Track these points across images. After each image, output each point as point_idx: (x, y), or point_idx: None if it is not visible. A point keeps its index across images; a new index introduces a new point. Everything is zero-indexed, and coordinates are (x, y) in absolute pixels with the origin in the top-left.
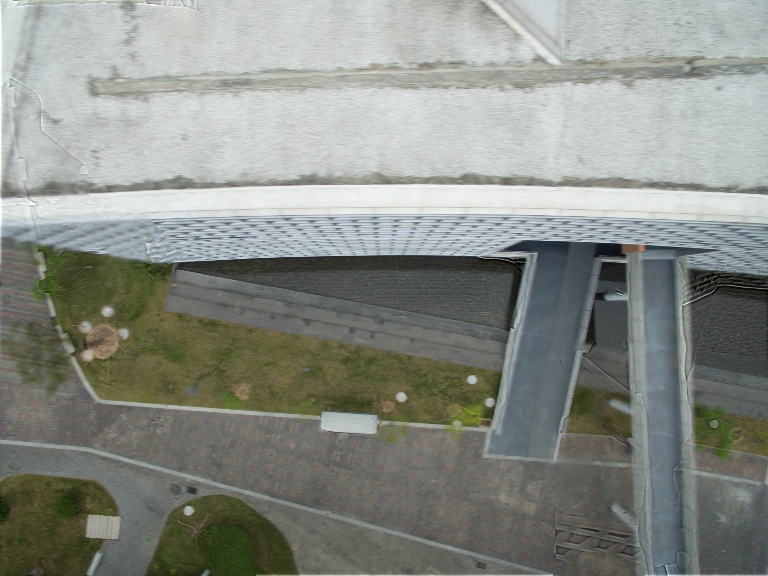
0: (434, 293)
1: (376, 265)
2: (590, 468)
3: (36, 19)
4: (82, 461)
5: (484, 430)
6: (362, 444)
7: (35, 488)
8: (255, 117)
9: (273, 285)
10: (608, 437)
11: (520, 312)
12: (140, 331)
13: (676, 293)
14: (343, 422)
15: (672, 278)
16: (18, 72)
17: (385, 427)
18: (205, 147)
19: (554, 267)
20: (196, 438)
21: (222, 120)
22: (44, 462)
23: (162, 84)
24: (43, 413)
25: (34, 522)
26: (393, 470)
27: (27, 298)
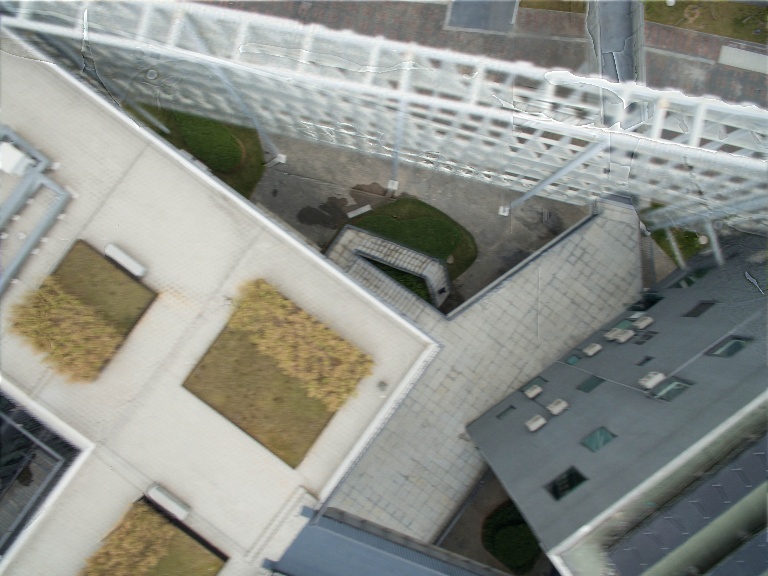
0: None
1: None
2: (548, 42)
3: None
4: (46, 25)
5: (445, 3)
6: (324, 13)
7: None
8: None
9: None
10: (567, 13)
11: None
12: None
13: None
14: None
15: None
16: None
17: None
18: None
19: None
20: (160, 4)
21: None
22: (8, 25)
23: None
24: None
25: None
26: (355, 39)
27: None
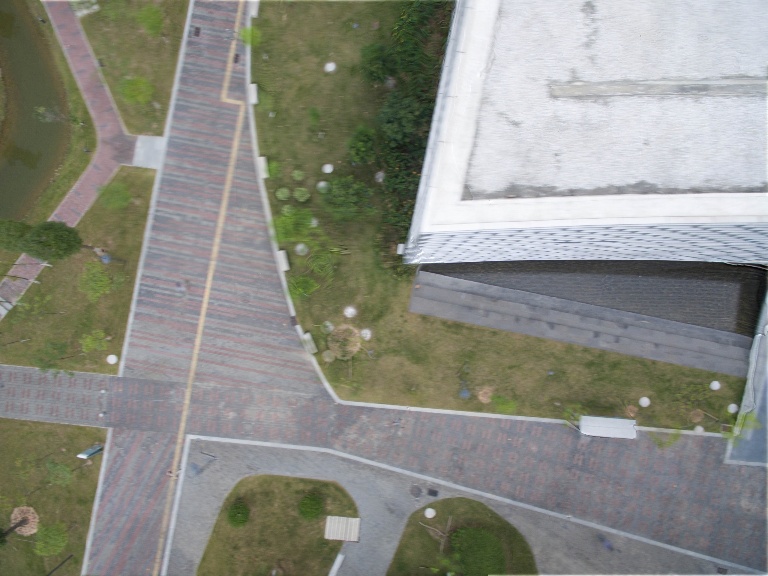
0: (676, 298)
1: (620, 269)
2: None
3: (500, 20)
4: (322, 462)
5: (726, 436)
6: (604, 448)
7: (275, 489)
8: (717, 123)
9: (516, 288)
10: None
11: None
12: (383, 332)
13: None
14: (603, 426)
15: None
16: (483, 73)
17: None
18: (667, 152)
19: None
20: (438, 440)
21: (684, 125)
22: (283, 462)
23: (619, 88)
24: (283, 413)
25: (275, 523)
26: (635, 475)
27: (266, 297)
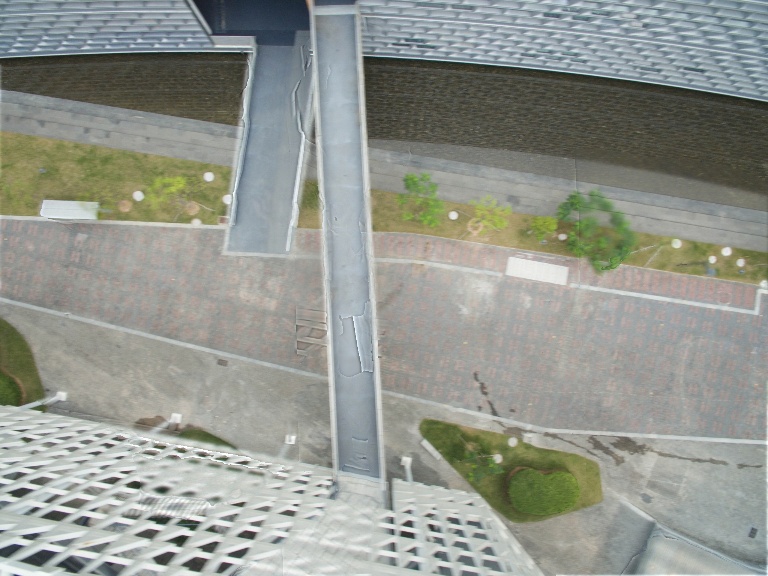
0: (172, 93)
1: (111, 65)
2: None
3: None
4: None
5: (223, 227)
6: (101, 245)
7: None
8: None
9: (10, 89)
10: None
11: (247, 101)
12: None
13: (356, 42)
14: (62, 208)
15: (353, 28)
16: None
17: (124, 227)
18: None
19: (279, 54)
20: None
21: None
22: None
23: None
24: None
25: None
26: (132, 270)
27: None
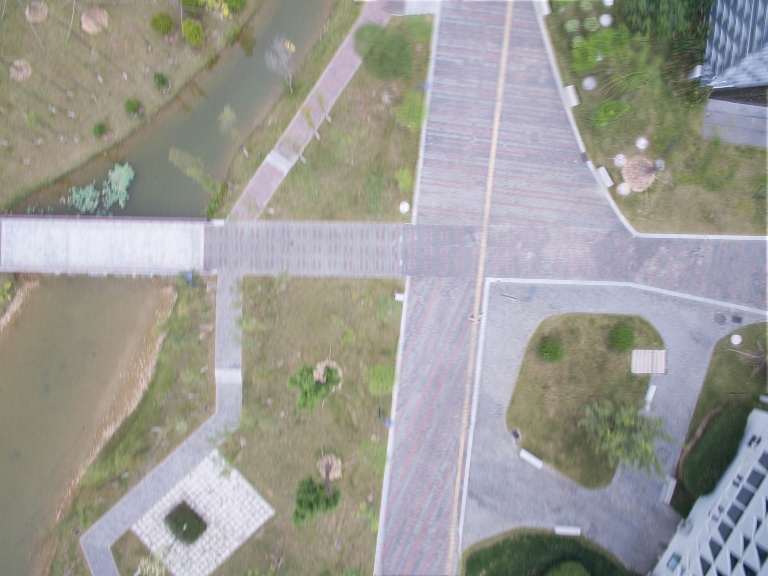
0: None
1: None
2: None
3: None
4: (624, 296)
5: None
6: None
7: (580, 326)
8: None
9: None
10: None
11: None
12: (676, 161)
13: None
14: None
15: None
16: None
17: None
18: None
19: None
20: (738, 267)
21: None
22: (585, 299)
23: None
24: (581, 250)
25: (583, 359)
26: None
27: (555, 135)
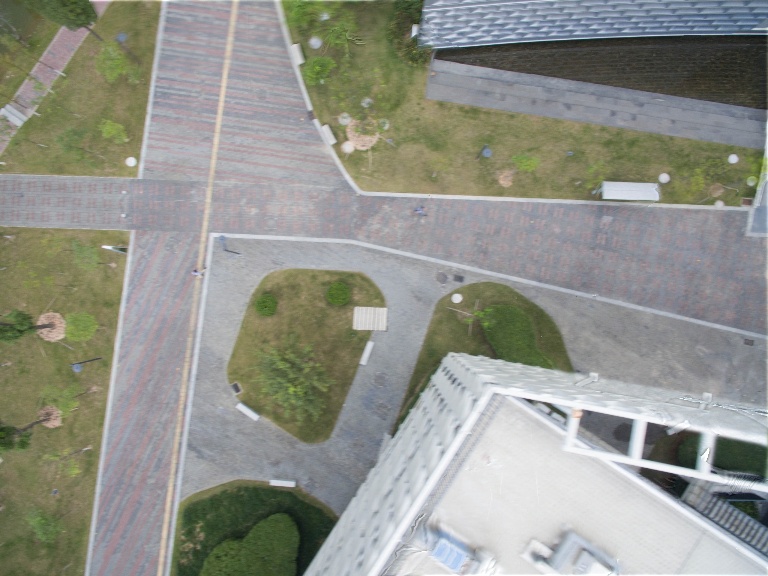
0: (690, 76)
1: (634, 48)
2: None
3: None
4: (347, 253)
5: (746, 209)
6: (626, 227)
7: (301, 281)
8: None
9: (531, 72)
10: None
11: None
12: (401, 121)
13: None
14: (626, 190)
15: None
16: None
17: (648, 209)
18: None
19: None
20: (461, 226)
21: None
22: (308, 256)
23: None
24: (305, 207)
25: (302, 315)
26: (658, 251)
27: (283, 93)
